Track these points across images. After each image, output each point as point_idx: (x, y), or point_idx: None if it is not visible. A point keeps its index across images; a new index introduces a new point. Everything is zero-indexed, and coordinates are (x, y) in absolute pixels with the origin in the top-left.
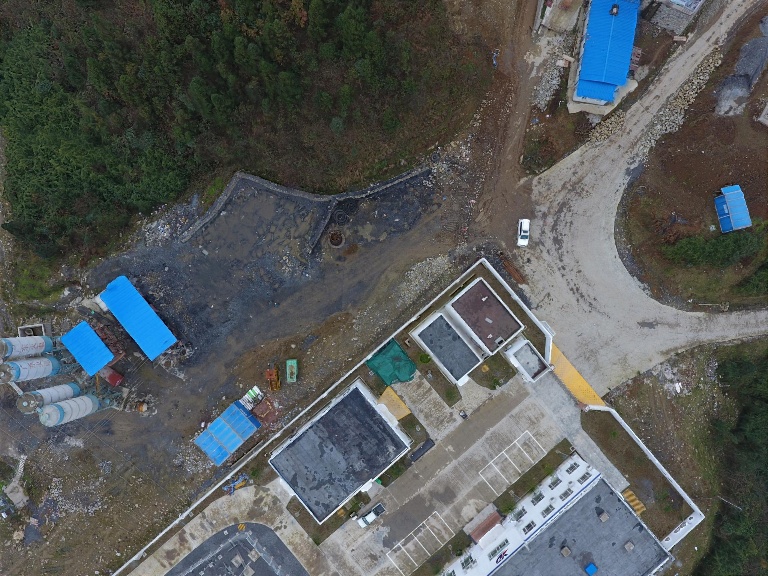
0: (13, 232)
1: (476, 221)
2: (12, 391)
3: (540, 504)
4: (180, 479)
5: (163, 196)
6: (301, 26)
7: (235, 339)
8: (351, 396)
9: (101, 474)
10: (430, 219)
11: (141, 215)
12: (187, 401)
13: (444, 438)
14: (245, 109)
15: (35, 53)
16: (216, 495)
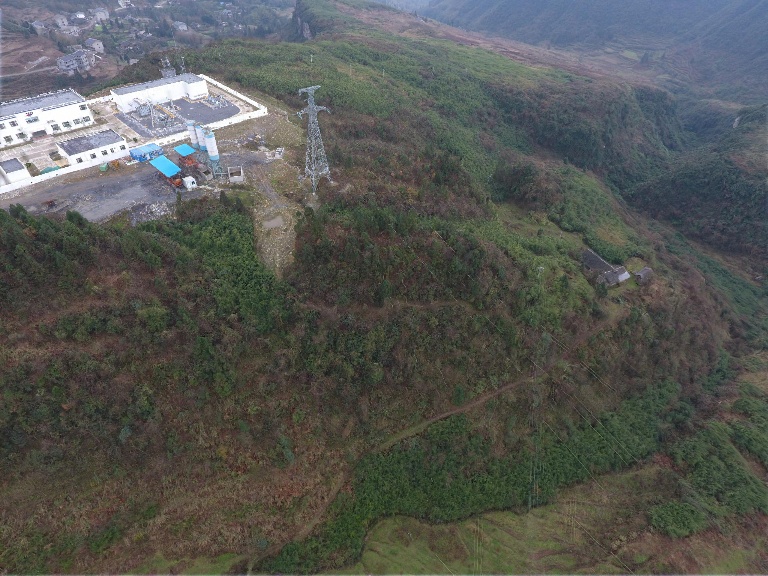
0: None
1: None
2: None
3: (6, 134)
4: None
5: None
6: None
7: None
8: None
9: None
10: None
11: None
12: None
13: (43, 156)
14: None
15: None
16: None
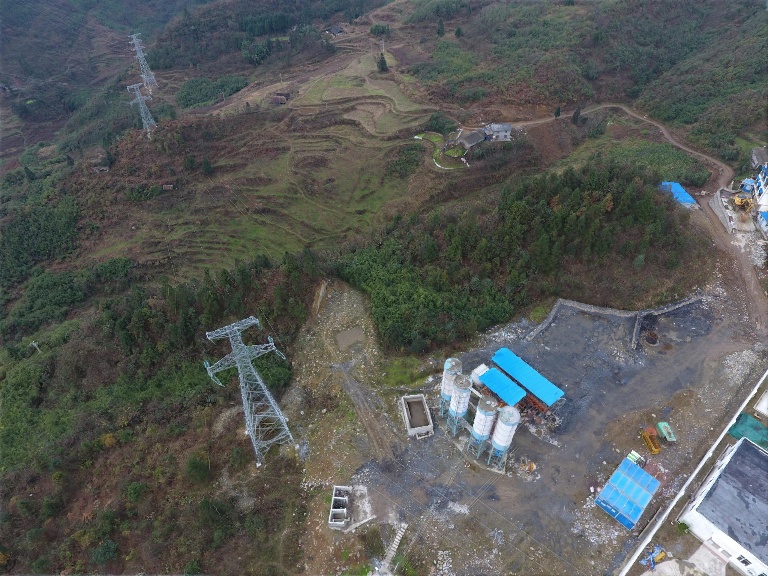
0: (393, 333)
1: (757, 329)
2: (390, 457)
3: None
4: (585, 552)
5: (501, 316)
6: (609, 211)
7: (596, 411)
8: (743, 448)
9: (493, 546)
10: (720, 328)
11: (478, 333)
12: (567, 466)
13: None
14: (568, 257)
15: (392, 250)
16: (635, 571)
